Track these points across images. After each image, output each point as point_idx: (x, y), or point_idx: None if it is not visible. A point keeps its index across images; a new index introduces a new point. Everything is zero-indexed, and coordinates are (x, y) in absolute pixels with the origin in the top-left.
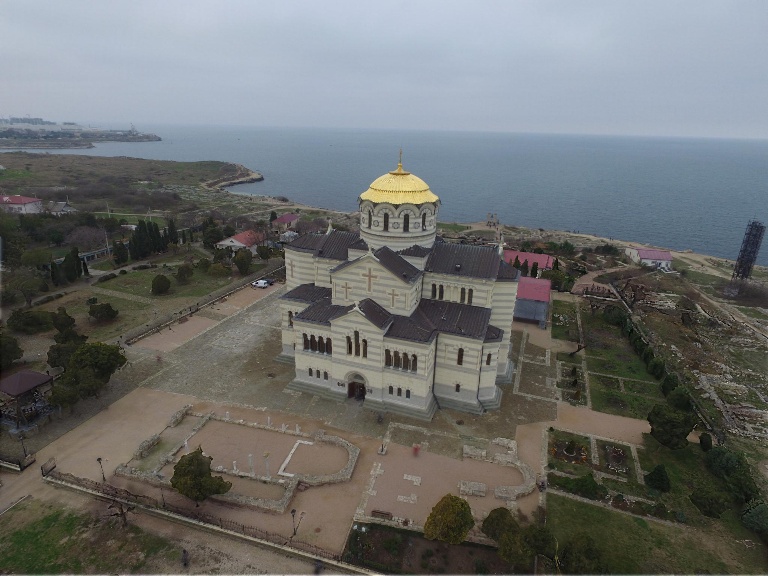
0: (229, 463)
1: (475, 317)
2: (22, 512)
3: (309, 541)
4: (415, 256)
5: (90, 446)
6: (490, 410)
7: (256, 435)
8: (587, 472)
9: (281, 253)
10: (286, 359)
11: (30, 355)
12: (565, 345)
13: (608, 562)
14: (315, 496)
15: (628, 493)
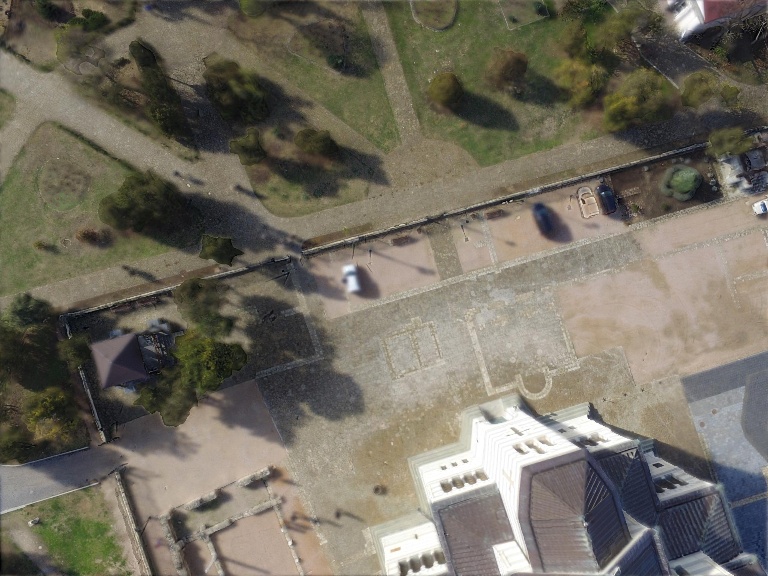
0: None
1: None
2: (88, 501)
3: None
4: None
5: (165, 453)
6: None
7: (287, 573)
8: None
9: (762, 60)
10: (416, 479)
11: (201, 187)
12: None
13: None
14: None
15: None
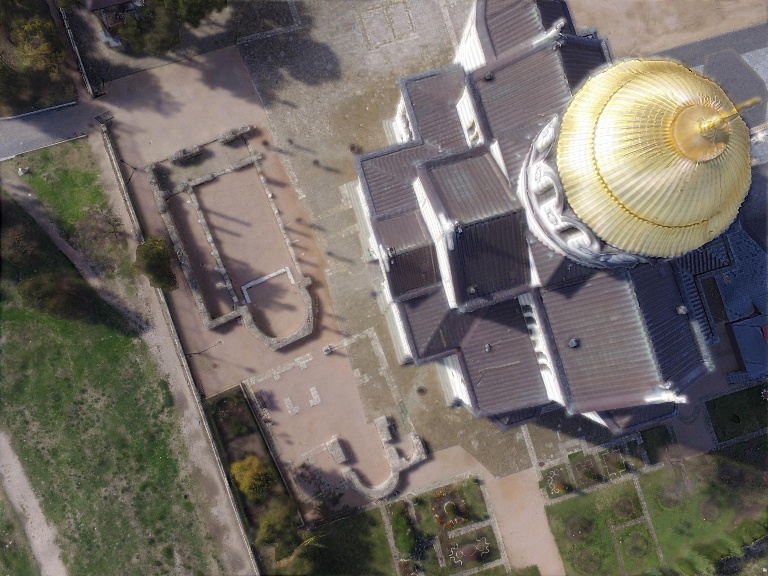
0: (223, 238)
1: (518, 387)
2: (76, 152)
3: (202, 368)
4: (538, 271)
5: (149, 110)
6: (465, 409)
7: (267, 225)
8: (430, 531)
9: None
10: (391, 136)
11: None
12: (695, 427)
13: (334, 574)
14: (241, 337)
15: (426, 571)
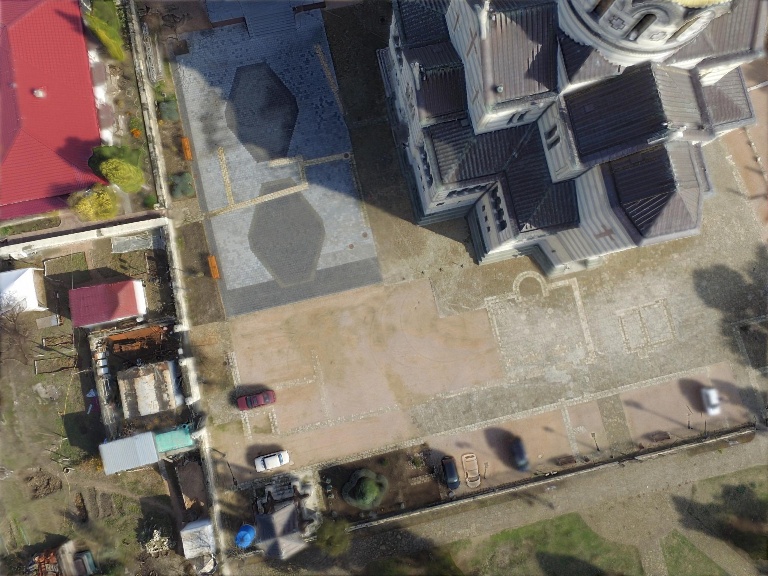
0: None
1: None
2: None
3: None
4: None
5: None
6: None
7: (759, 134)
8: None
9: None
10: None
11: None
12: None
13: None
14: None
15: None
